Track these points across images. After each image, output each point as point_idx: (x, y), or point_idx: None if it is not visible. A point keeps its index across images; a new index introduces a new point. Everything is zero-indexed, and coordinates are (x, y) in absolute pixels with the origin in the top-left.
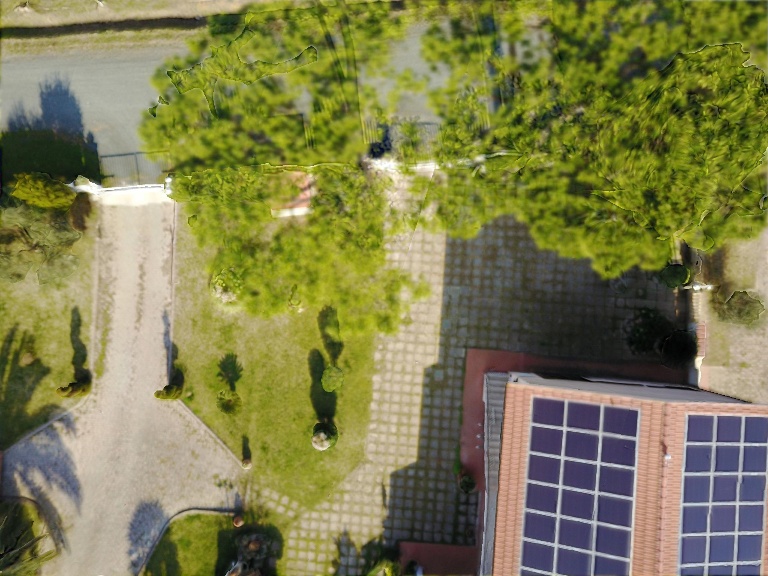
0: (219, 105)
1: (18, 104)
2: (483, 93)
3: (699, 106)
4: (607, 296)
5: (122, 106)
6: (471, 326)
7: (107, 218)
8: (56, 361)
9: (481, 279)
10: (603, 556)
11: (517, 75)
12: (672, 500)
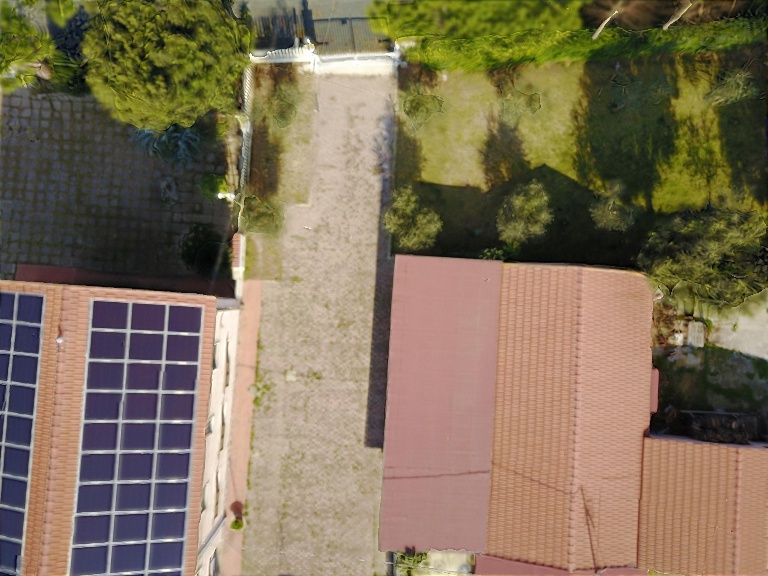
0: None
1: None
2: (41, 2)
3: None
4: (163, 211)
5: None
6: (23, 241)
7: None
8: None
9: (35, 193)
10: (10, 446)
11: None
12: (73, 386)
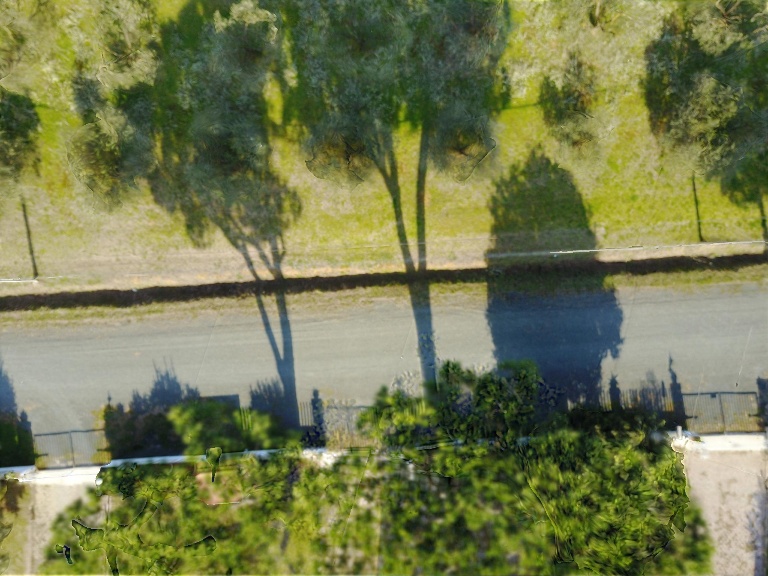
0: (155, 385)
1: None
2: (418, 377)
3: (611, 495)
4: None
5: (56, 385)
6: None
7: (41, 498)
8: None
9: (415, 565)
10: None
11: (452, 360)
12: None
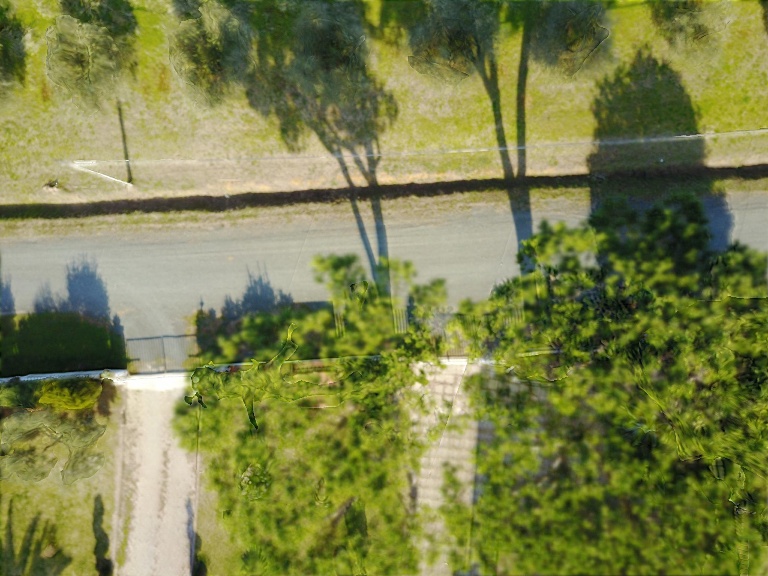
0: (248, 290)
1: (45, 285)
2: (518, 284)
3: (753, 373)
4: (644, 501)
5: (150, 289)
6: (503, 528)
7: (132, 403)
8: (78, 551)
9: (514, 478)
10: None
11: (554, 267)
12: None
